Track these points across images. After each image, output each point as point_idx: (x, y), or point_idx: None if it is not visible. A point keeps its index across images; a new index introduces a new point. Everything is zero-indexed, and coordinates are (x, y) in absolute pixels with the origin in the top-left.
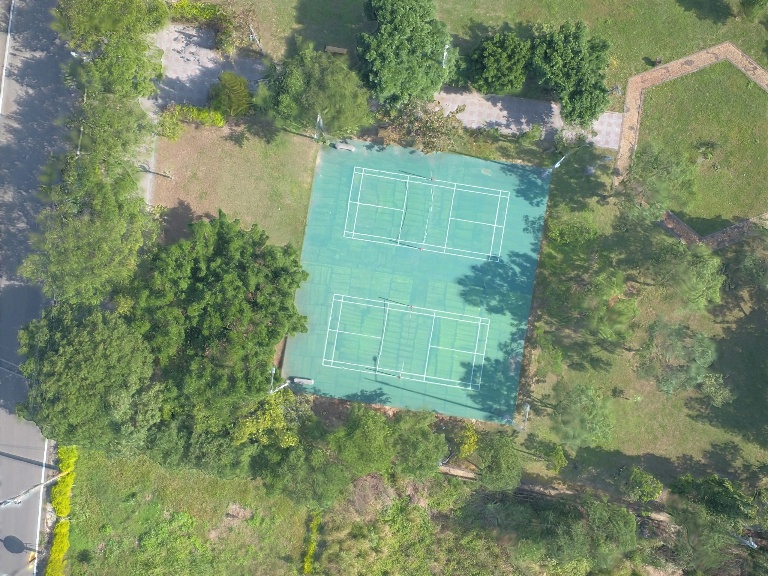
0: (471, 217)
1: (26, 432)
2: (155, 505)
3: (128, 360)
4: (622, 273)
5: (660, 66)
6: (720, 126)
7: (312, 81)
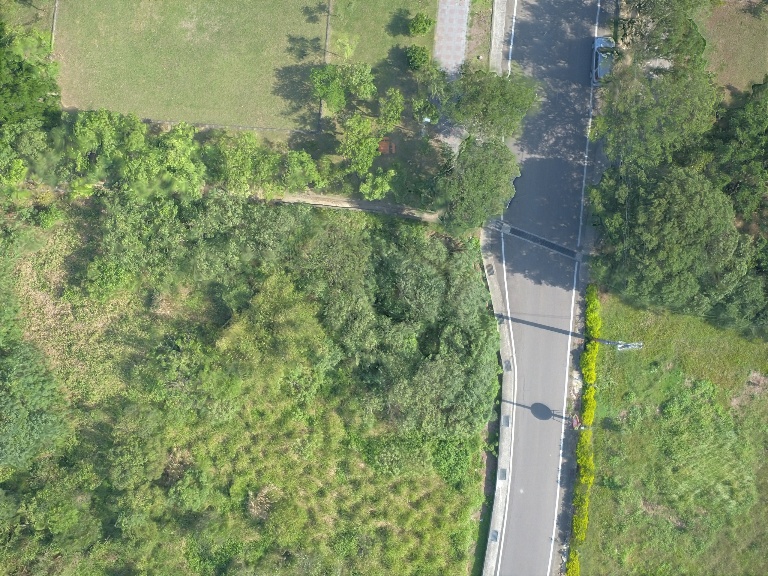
0: None
1: (551, 301)
2: (677, 373)
3: (723, 212)
4: None
5: None
6: None
7: None
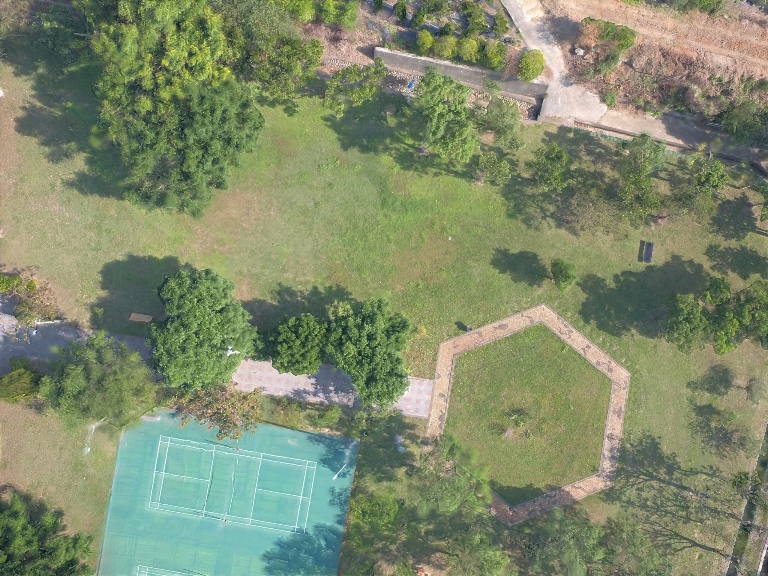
0: (277, 488)
1: None
2: None
3: None
4: (430, 543)
5: (473, 330)
6: (533, 392)
7: (87, 392)
